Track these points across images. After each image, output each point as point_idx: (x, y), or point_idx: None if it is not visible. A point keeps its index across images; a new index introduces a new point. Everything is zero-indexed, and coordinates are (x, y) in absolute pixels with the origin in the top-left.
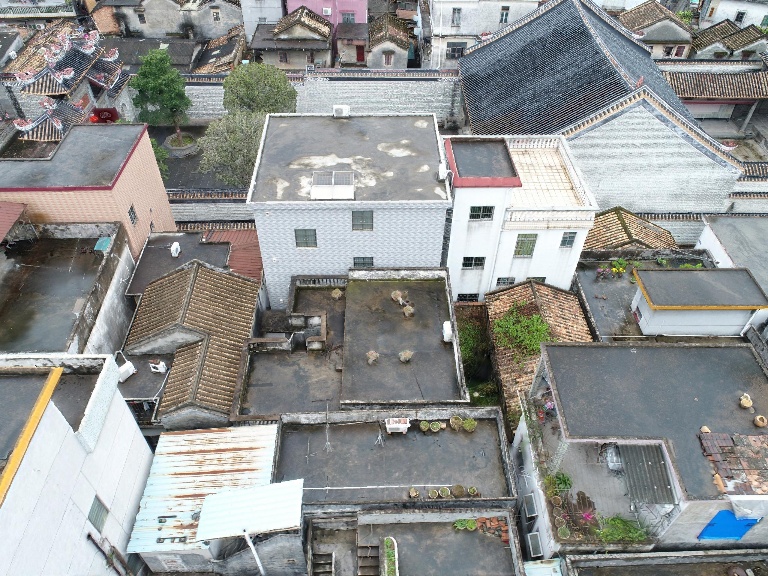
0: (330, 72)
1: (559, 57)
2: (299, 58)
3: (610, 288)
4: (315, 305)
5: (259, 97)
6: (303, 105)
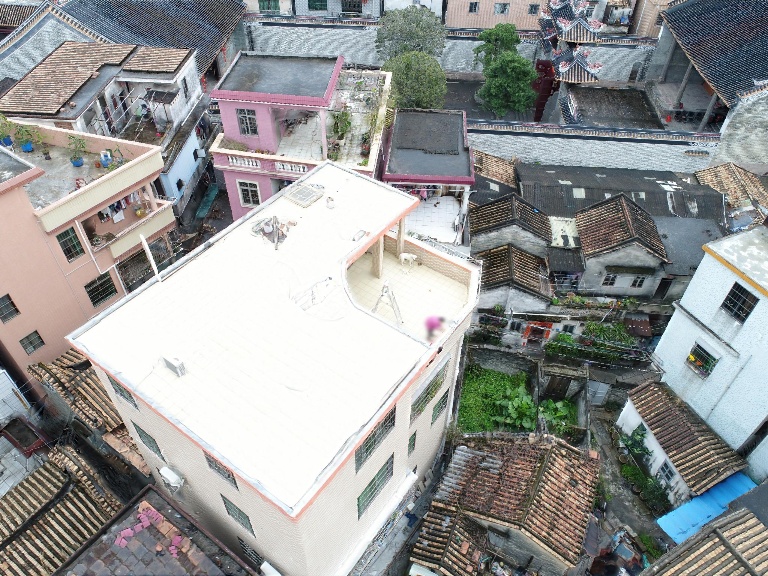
0: None
1: (133, 1)
2: None
3: None
4: None
5: None
6: None
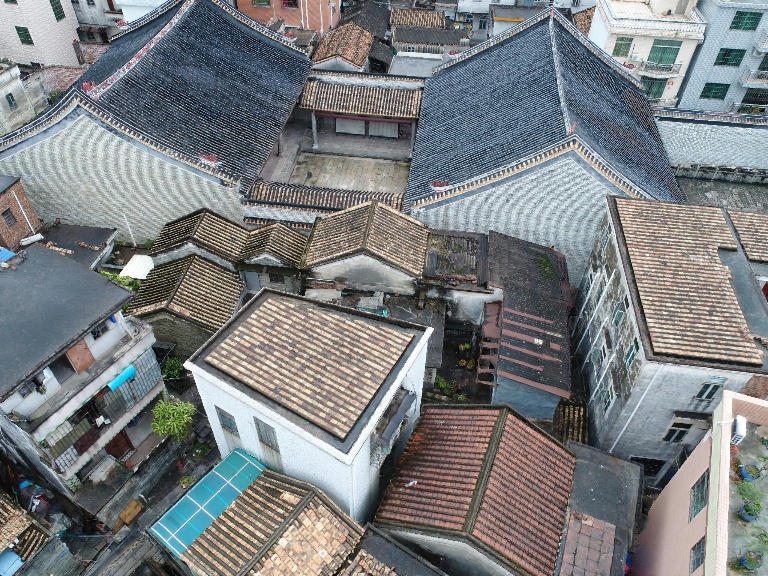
0: None
1: None
2: None
3: None
4: None
5: None
6: None
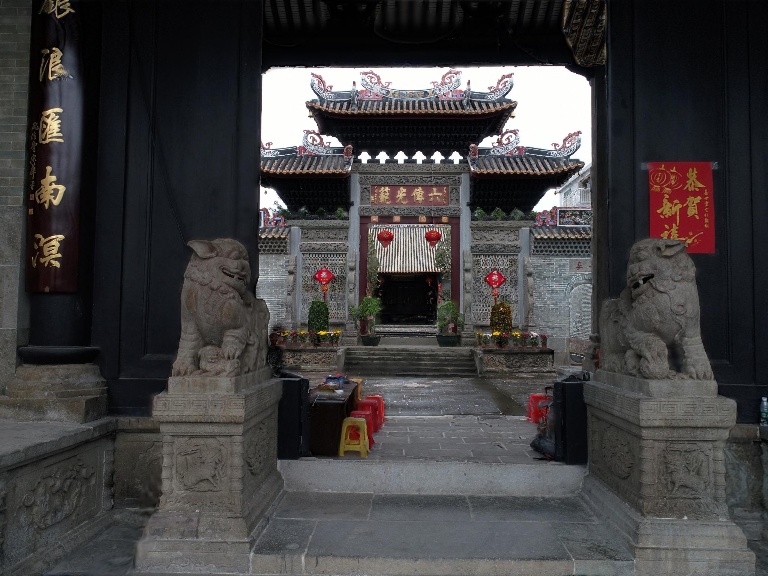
0: None
1: None
2: None
3: None
4: None
5: None
6: None
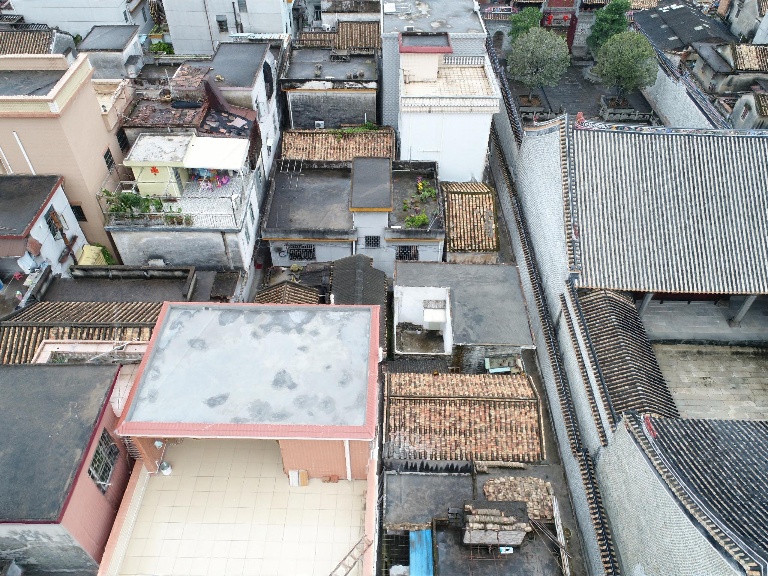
0: (692, 86)
1: None
2: (710, 73)
3: (406, 185)
4: (363, 61)
5: (610, 53)
6: (669, 103)
